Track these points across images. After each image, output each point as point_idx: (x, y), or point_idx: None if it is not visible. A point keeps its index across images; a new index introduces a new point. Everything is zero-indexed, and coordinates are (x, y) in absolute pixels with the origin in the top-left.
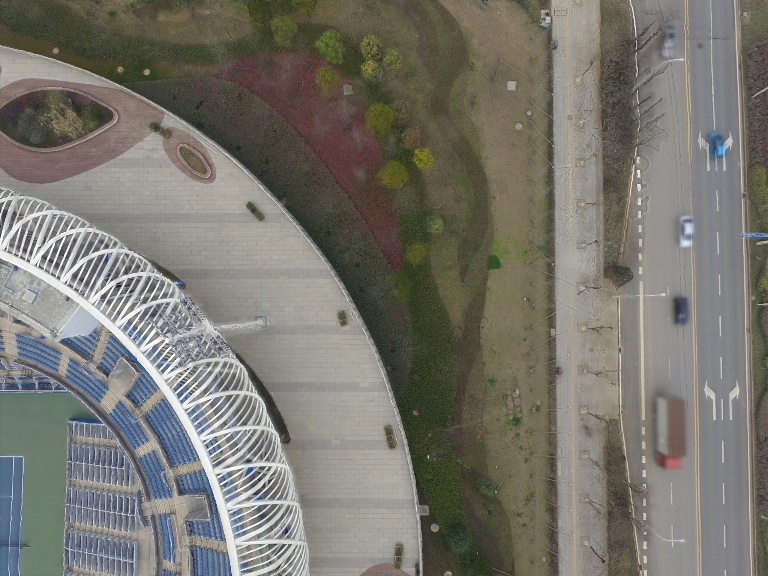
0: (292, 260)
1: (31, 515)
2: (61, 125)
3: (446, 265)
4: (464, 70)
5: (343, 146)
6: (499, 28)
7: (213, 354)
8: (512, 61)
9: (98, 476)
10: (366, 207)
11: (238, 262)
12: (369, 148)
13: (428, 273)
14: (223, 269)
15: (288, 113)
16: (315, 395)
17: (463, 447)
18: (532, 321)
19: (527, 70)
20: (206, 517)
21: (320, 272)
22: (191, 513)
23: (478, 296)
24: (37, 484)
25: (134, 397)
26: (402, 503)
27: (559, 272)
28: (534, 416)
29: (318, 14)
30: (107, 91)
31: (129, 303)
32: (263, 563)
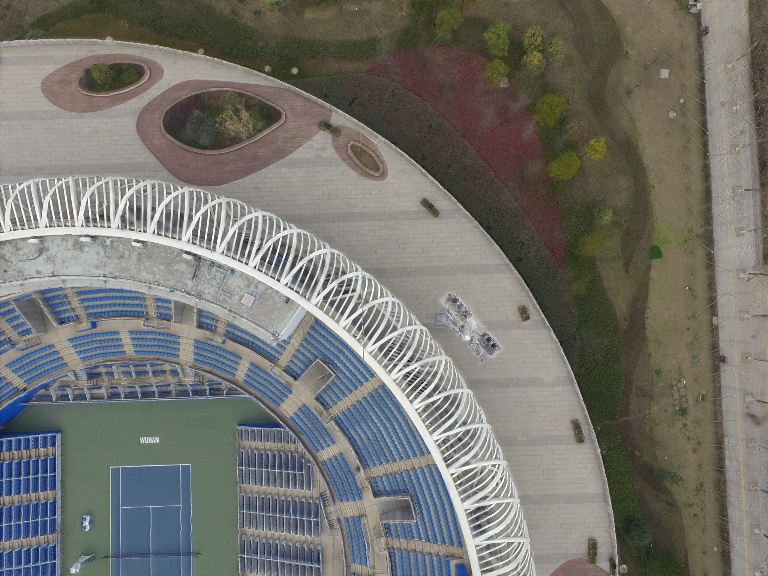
0: (469, 256)
1: (201, 523)
2: (236, 126)
3: (610, 256)
4: (619, 59)
5: (501, 139)
6: (650, 16)
7: (435, 352)
8: (664, 49)
9: (273, 481)
10: (526, 200)
11: (415, 259)
12: (528, 141)
13: (593, 265)
14: (400, 267)
15: (442, 108)
16: (499, 391)
17: (632, 439)
18: (694, 310)
19: (679, 57)
20: (410, 518)
21: (498, 267)
22: (384, 515)
23: (642, 287)
24: (206, 491)
25: (323, 399)
26: (592, 497)
27: (719, 260)
28: (700, 405)
29: (470, 7)
30: (272, 90)
31: (353, 303)
32: (503, 562)
